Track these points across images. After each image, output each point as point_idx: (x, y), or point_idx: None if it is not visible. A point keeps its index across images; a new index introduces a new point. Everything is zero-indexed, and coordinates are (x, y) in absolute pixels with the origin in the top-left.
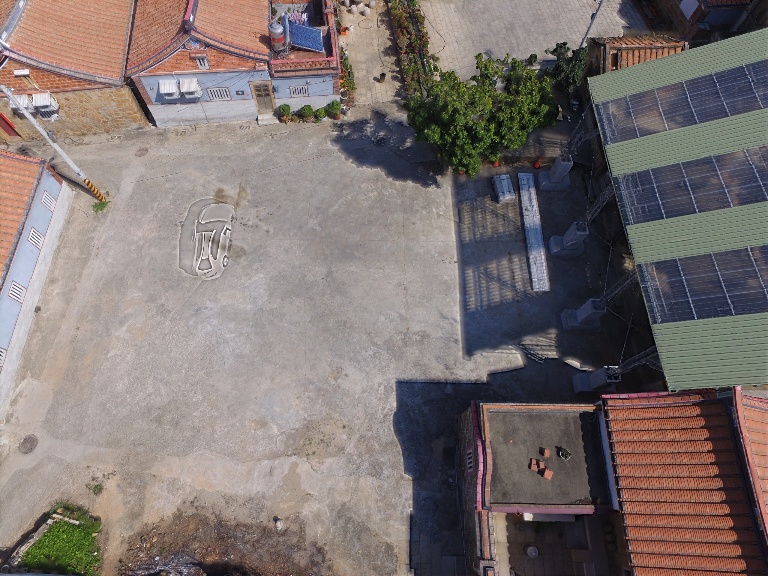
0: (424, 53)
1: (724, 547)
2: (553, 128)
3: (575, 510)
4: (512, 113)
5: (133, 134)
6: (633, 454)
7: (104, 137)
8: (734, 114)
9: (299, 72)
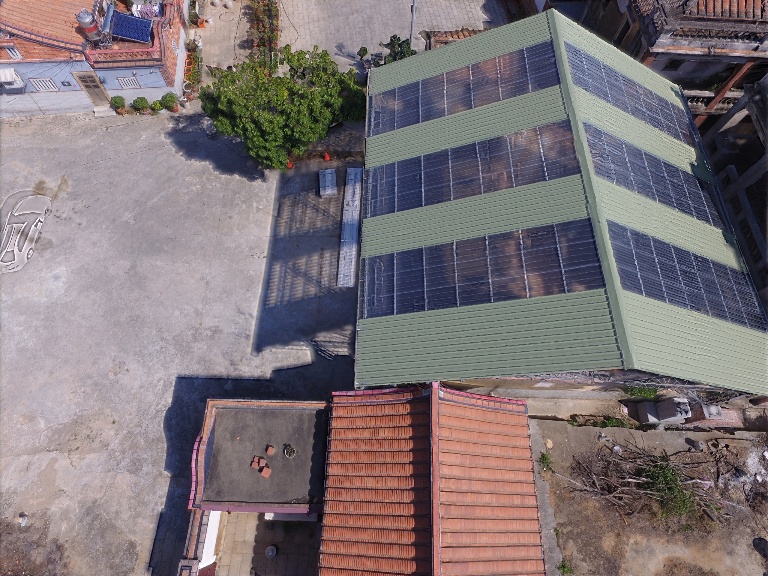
0: (272, 46)
1: (401, 548)
2: None
3: (288, 509)
4: (301, 105)
5: None
6: (345, 452)
7: None
8: (477, 106)
9: (121, 63)
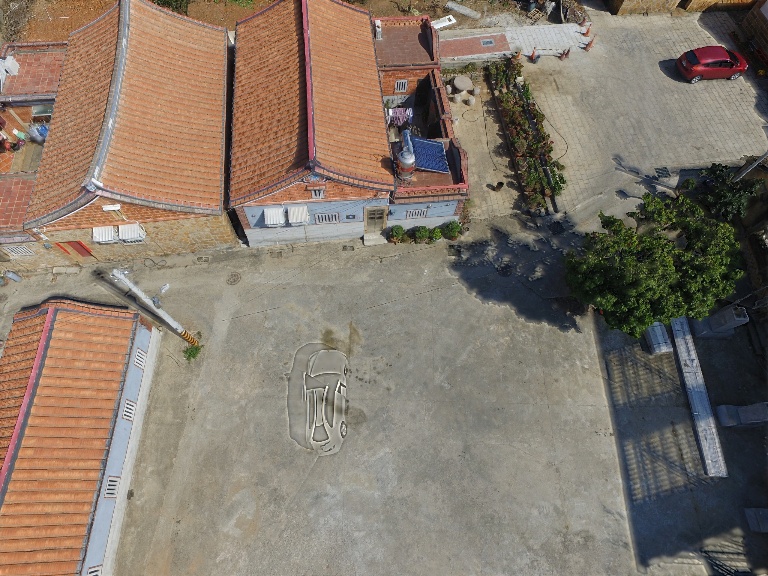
0: (547, 160)
1: None
2: None
3: None
4: (704, 282)
5: (222, 255)
6: None
7: (189, 258)
8: None
9: (423, 198)
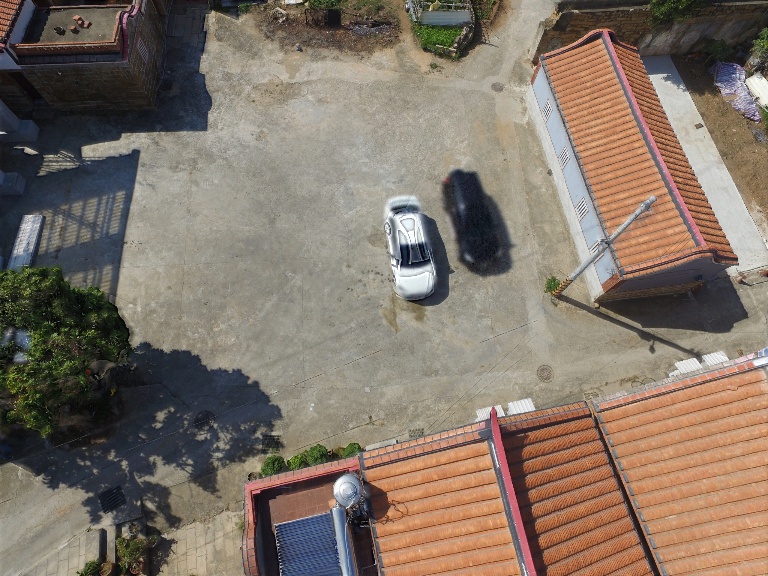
0: None
1: None
2: None
3: None
4: None
5: None
6: None
7: None
8: None
9: None
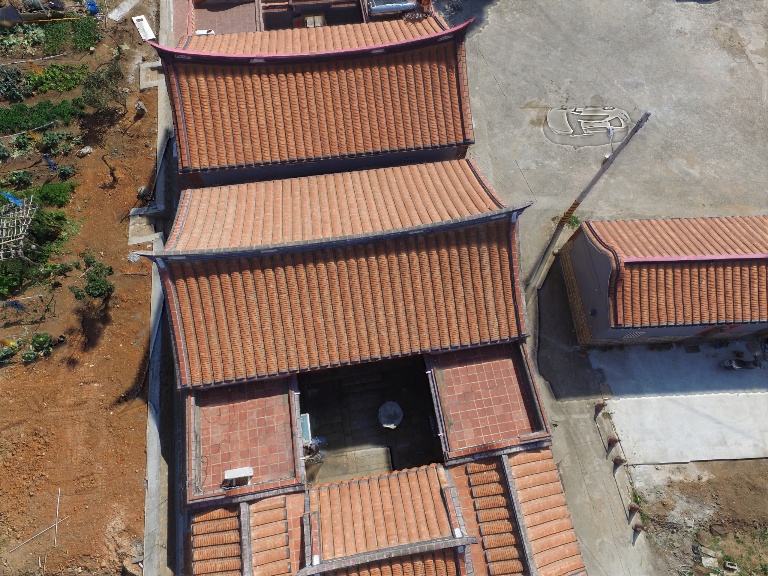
0: None
1: None
2: None
3: None
4: None
5: None
6: None
7: None
8: None
9: None
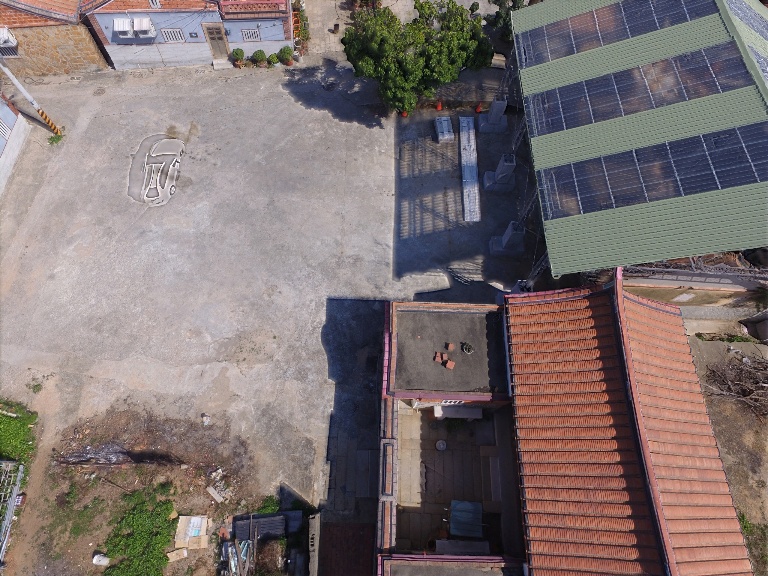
0: (377, 5)
1: (598, 418)
2: (496, 76)
3: (473, 397)
4: (442, 46)
5: (92, 75)
6: (527, 344)
7: (64, 78)
8: (634, 36)
9: (249, 14)
